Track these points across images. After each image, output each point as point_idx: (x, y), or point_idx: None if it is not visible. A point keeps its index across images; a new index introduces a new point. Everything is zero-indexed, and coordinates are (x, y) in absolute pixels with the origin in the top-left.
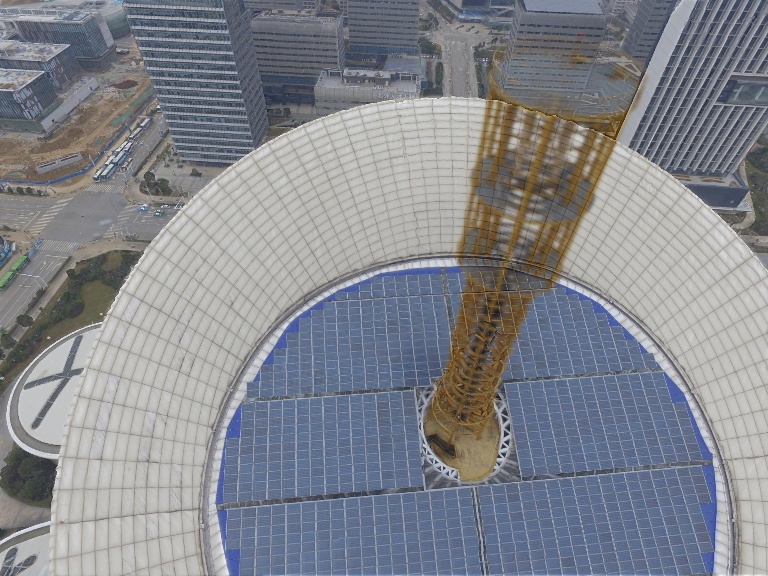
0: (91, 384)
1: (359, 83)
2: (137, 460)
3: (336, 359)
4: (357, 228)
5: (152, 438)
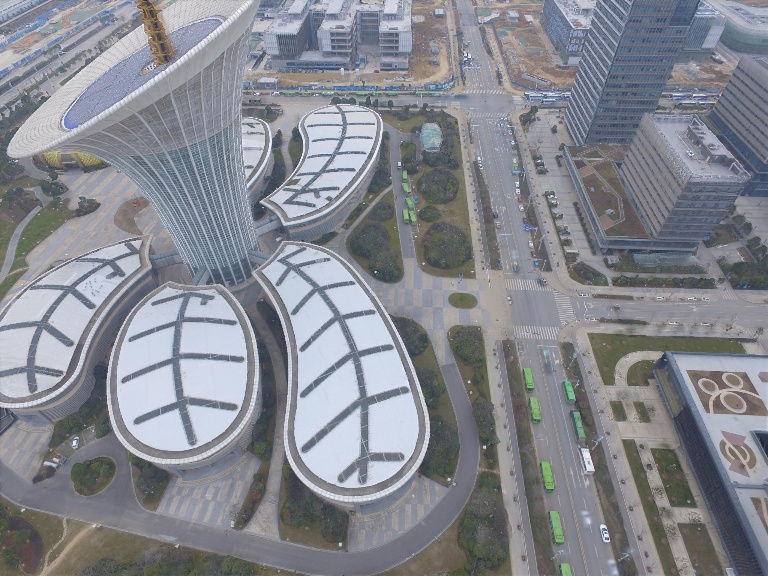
0: None
1: (693, 142)
2: None
3: None
4: None
5: None
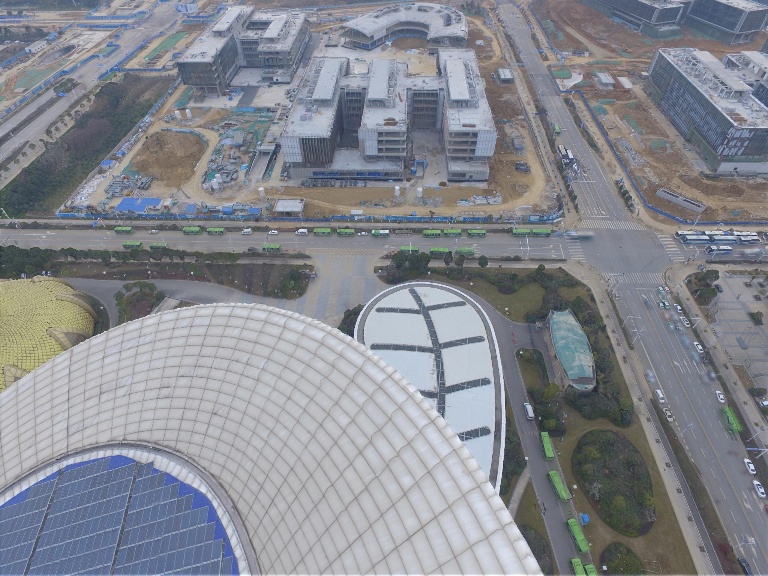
0: (150, 323)
1: None
2: (102, 385)
3: (148, 575)
4: (303, 575)
5: (115, 389)
